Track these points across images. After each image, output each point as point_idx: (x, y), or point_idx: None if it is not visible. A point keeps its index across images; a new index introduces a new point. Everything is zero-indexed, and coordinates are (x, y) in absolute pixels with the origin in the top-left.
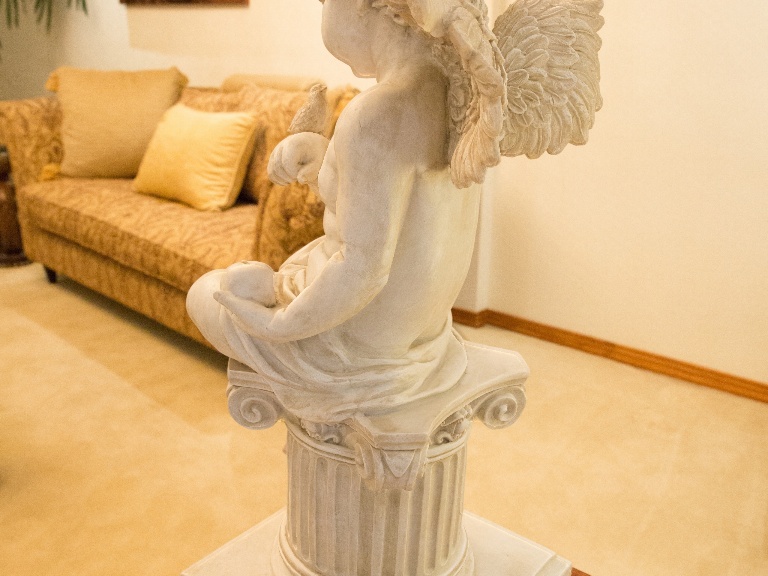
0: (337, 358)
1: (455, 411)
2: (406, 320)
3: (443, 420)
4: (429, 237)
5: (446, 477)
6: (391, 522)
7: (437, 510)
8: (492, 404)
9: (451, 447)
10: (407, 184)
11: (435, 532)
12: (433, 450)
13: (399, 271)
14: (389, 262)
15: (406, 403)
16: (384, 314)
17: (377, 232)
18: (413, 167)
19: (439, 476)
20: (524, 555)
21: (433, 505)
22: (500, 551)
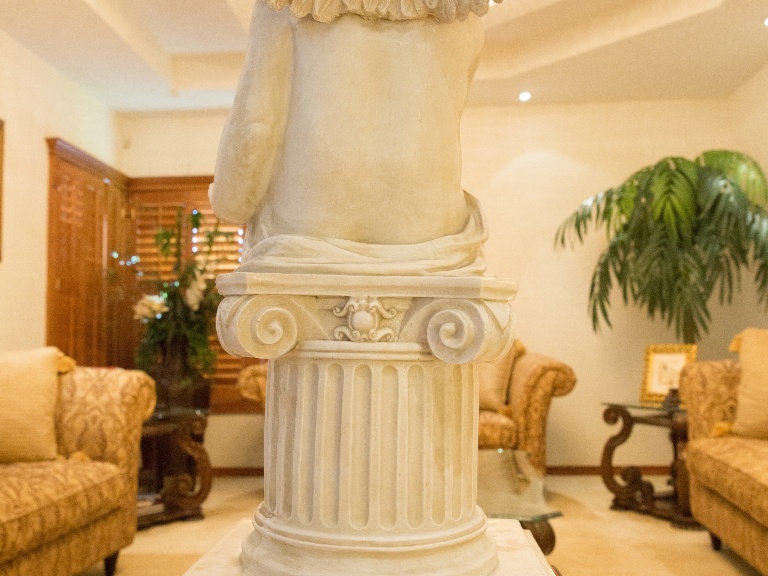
0: (262, 234)
1: (345, 295)
2: (304, 186)
3: (315, 293)
4: (309, 89)
5: (347, 389)
6: (293, 435)
7: (340, 435)
8: (432, 319)
9: (348, 346)
10: (282, 37)
11: (338, 467)
12: (324, 342)
13: (291, 131)
14: (257, 109)
15: (280, 267)
16: (287, 181)
17: (245, 80)
18: (287, 20)
19: (341, 387)
20: None
21: (336, 427)
22: None
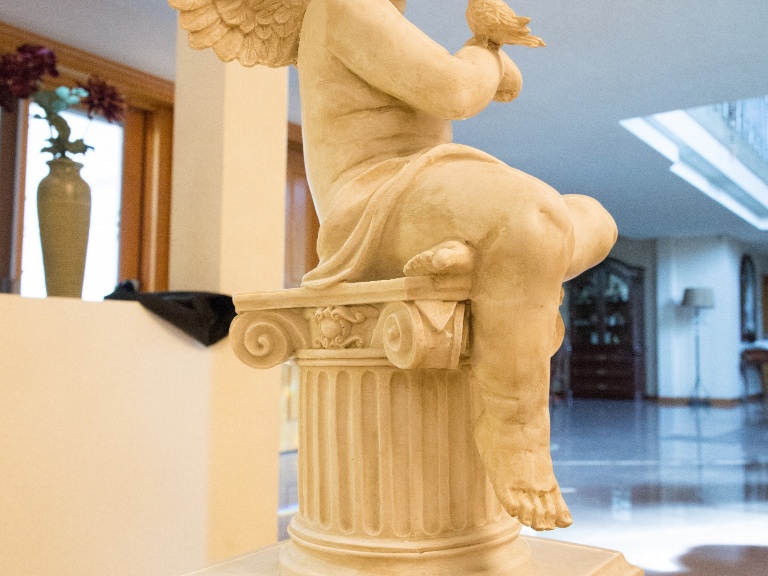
0: None
1: None
2: None
3: None
4: None
5: None
6: None
7: None
8: None
9: None
10: None
11: None
12: None
13: None
14: None
15: None
16: None
17: None
18: None
19: None
20: (208, 572)
21: None
22: (238, 574)
